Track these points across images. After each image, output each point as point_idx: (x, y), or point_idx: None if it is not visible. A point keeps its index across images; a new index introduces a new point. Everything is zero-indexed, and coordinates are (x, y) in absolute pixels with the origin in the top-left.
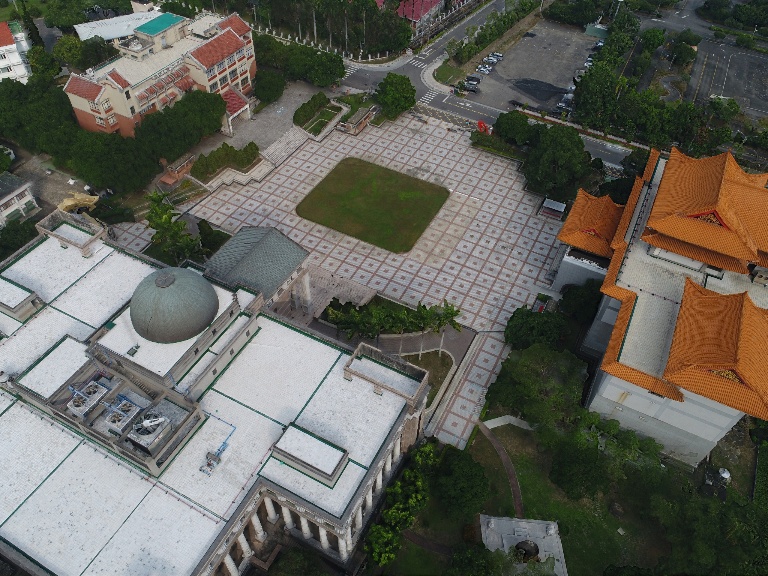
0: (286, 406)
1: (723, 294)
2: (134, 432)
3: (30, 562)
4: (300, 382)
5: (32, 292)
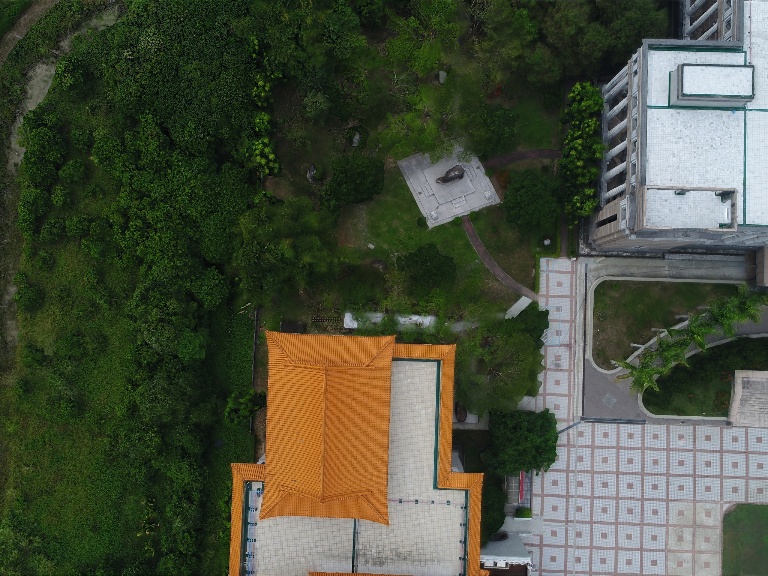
0: (764, 131)
1: (330, 546)
2: None
3: None
4: (767, 165)
5: None
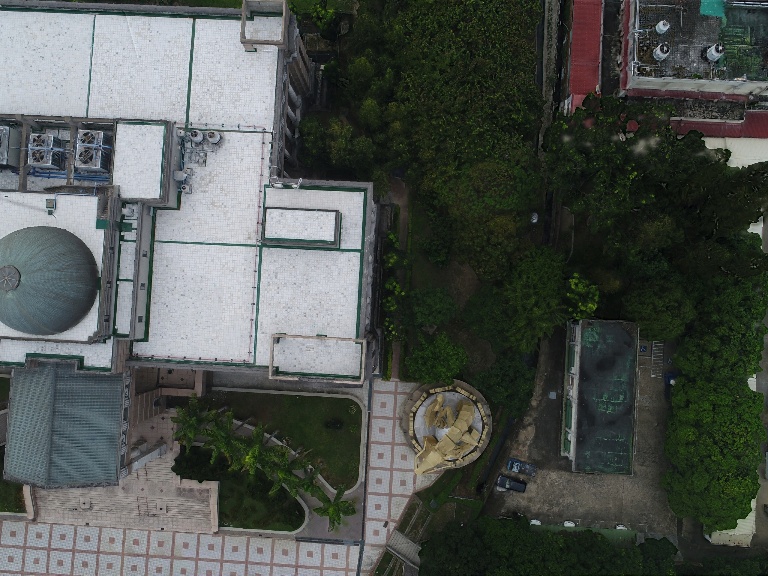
0: None
1: None
2: (2, 132)
3: (36, 5)
4: None
5: (266, 240)
